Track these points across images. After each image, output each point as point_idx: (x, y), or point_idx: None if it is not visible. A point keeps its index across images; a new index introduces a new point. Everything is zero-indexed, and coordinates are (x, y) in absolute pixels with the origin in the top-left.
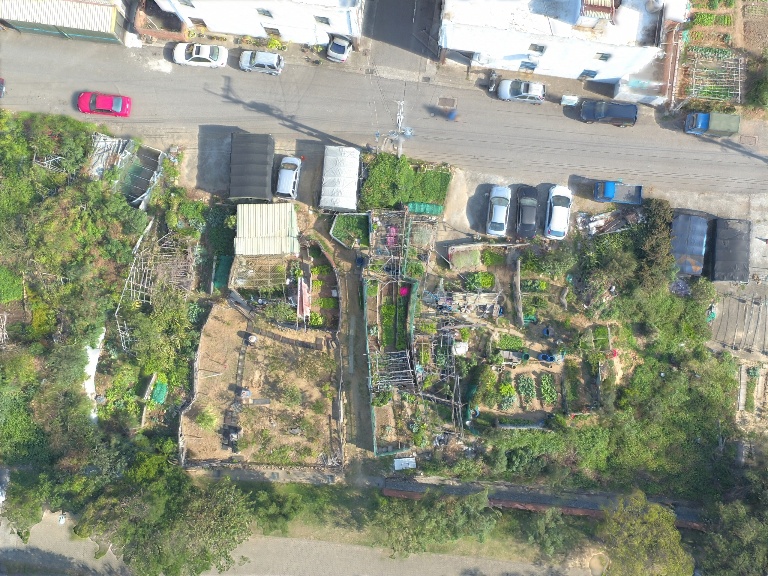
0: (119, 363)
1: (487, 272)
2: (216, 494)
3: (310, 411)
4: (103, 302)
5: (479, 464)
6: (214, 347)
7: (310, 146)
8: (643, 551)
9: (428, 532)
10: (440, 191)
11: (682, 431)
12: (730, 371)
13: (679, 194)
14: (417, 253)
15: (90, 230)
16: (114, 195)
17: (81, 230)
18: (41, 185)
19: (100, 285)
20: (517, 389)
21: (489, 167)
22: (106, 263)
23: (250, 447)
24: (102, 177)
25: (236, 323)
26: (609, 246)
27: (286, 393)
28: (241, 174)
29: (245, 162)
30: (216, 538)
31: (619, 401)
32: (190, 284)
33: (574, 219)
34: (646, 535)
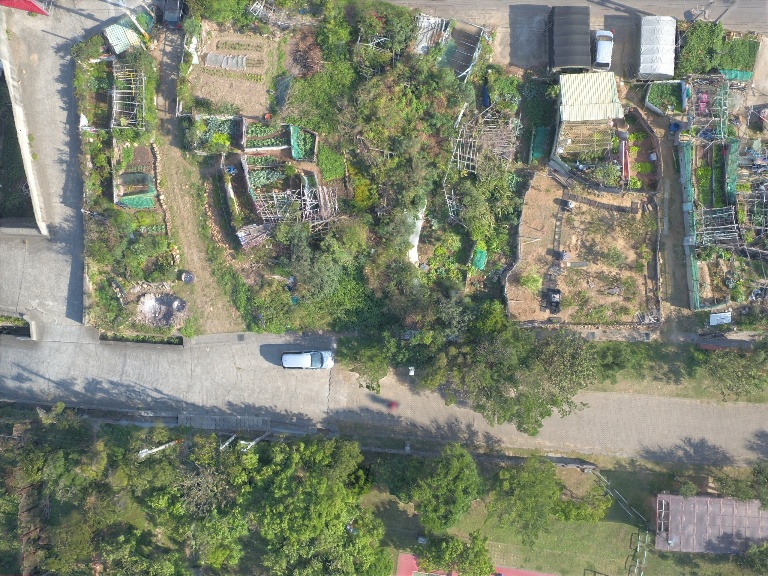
0: (439, 233)
1: None
2: (565, 340)
3: (626, 272)
4: (432, 173)
5: None
6: (531, 215)
7: (618, 21)
8: None
9: (764, 373)
10: (749, 58)
11: None
12: None
13: None
14: (728, 118)
15: (415, 106)
16: (440, 71)
17: (406, 107)
18: (368, 65)
19: (425, 158)
20: None
21: None
22: (428, 138)
23: (567, 308)
24: (428, 55)
25: (552, 191)
26: None
27: (610, 253)
28: (565, 45)
29: (569, 33)
30: (567, 381)
31: None
32: (510, 155)
33: None
34: None
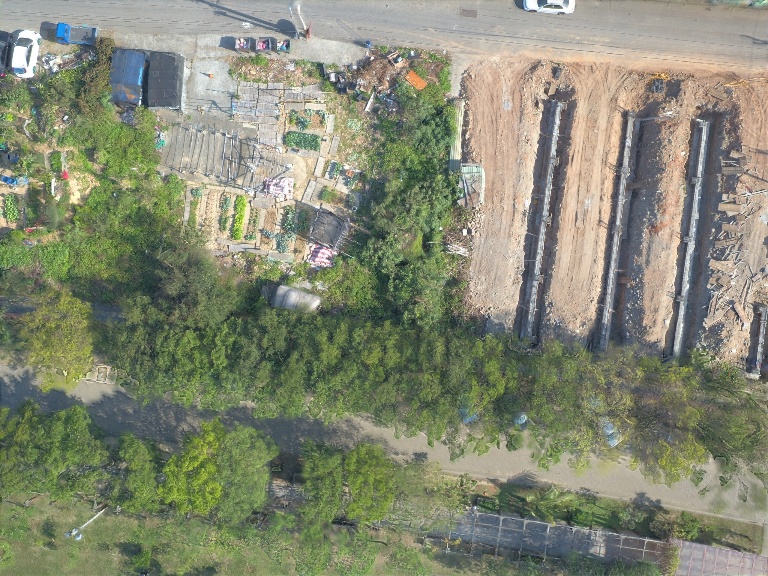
0: None
1: None
2: None
3: None
4: None
5: None
6: None
7: None
8: (42, 332)
9: None
10: None
11: (128, 243)
12: (175, 191)
13: (136, 36)
14: None
15: None
16: None
17: None
18: None
19: None
20: None
21: None
22: None
23: None
24: None
25: None
26: (61, 80)
27: None
28: None
29: None
30: None
31: (73, 218)
32: None
33: (42, 60)
34: (49, 319)
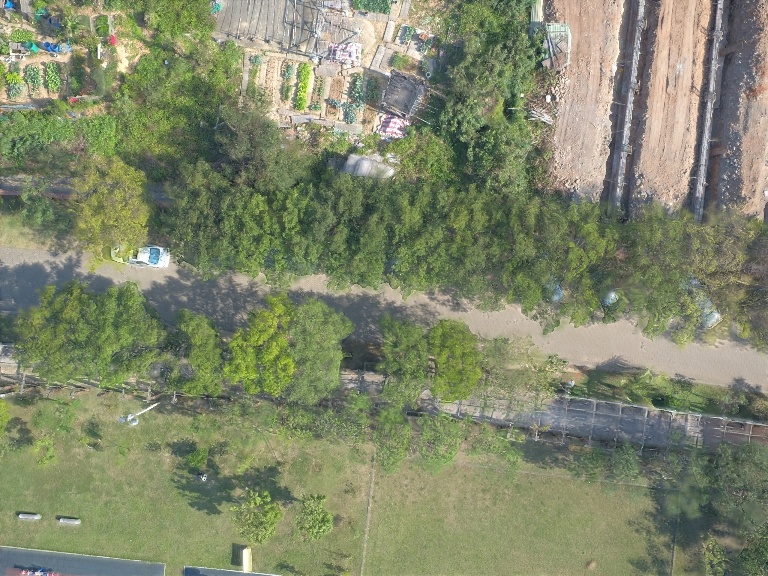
0: None
1: None
2: None
3: None
4: None
5: None
6: None
7: None
8: (94, 197)
9: None
10: None
11: (182, 114)
12: (232, 58)
13: None
14: None
15: None
16: None
17: None
18: None
19: None
20: (24, 78)
21: None
22: None
23: None
24: None
25: None
26: None
27: None
28: None
29: None
30: None
31: (121, 86)
32: None
33: None
34: (100, 184)
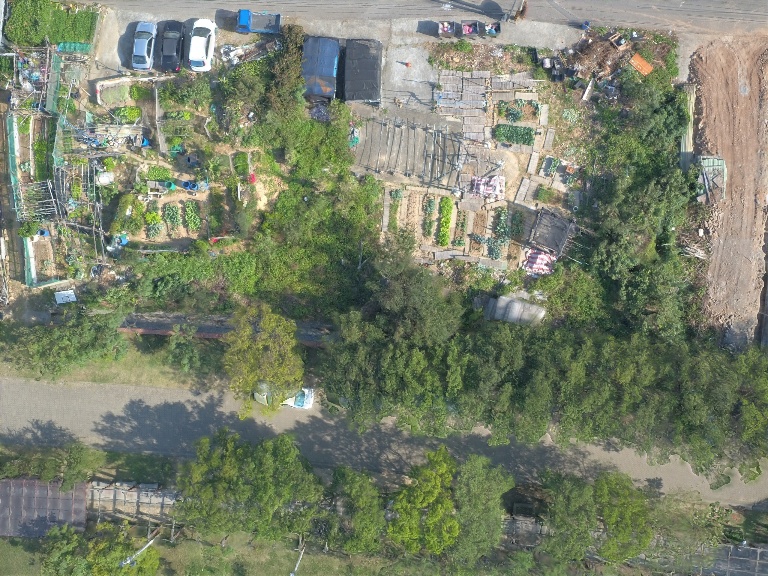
0: None
1: (135, 106)
2: None
3: None
4: None
5: (122, 289)
6: None
7: None
8: (249, 354)
9: (63, 351)
10: (90, 30)
11: (324, 252)
12: (373, 193)
13: (323, 23)
14: None
15: None
16: None
17: None
18: None
19: None
20: (163, 217)
21: (139, 5)
22: None
23: None
24: None
25: None
26: (245, 73)
27: None
28: None
29: None
30: None
31: (261, 225)
32: None
33: (219, 51)
34: (255, 339)
